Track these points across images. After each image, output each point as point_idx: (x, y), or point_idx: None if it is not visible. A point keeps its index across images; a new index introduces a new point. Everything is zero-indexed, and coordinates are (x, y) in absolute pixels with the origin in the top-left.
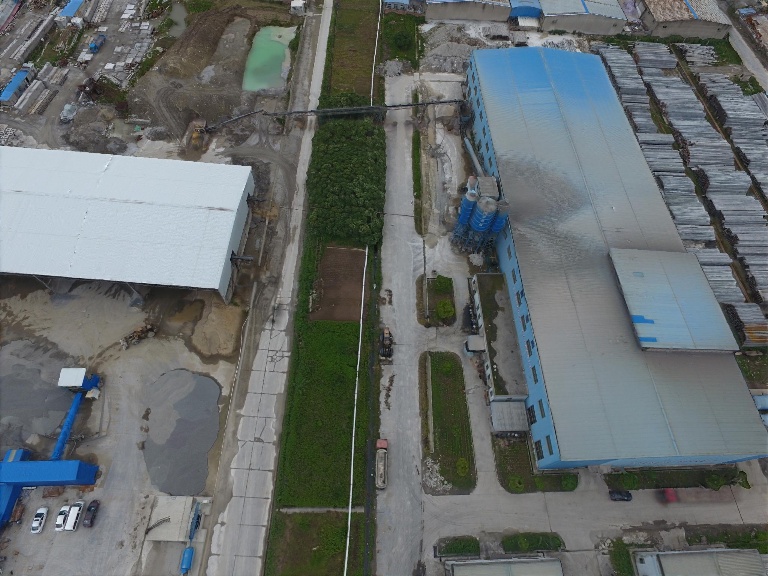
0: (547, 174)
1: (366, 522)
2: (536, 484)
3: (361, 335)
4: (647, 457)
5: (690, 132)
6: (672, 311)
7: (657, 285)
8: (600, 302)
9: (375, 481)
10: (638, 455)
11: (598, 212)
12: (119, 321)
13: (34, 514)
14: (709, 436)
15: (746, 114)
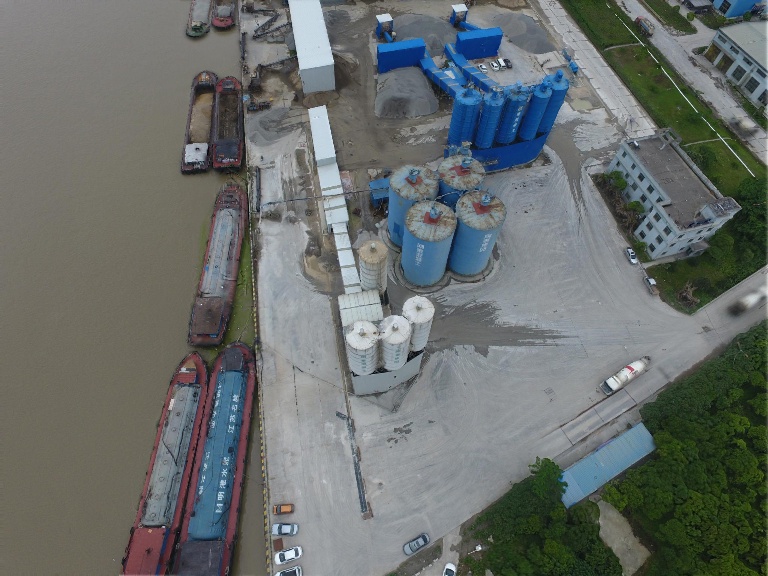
0: None
1: None
2: (730, 21)
3: None
4: None
5: None
6: None
7: None
8: None
9: (648, 30)
10: None
11: None
12: (449, 2)
13: None
14: None
15: None
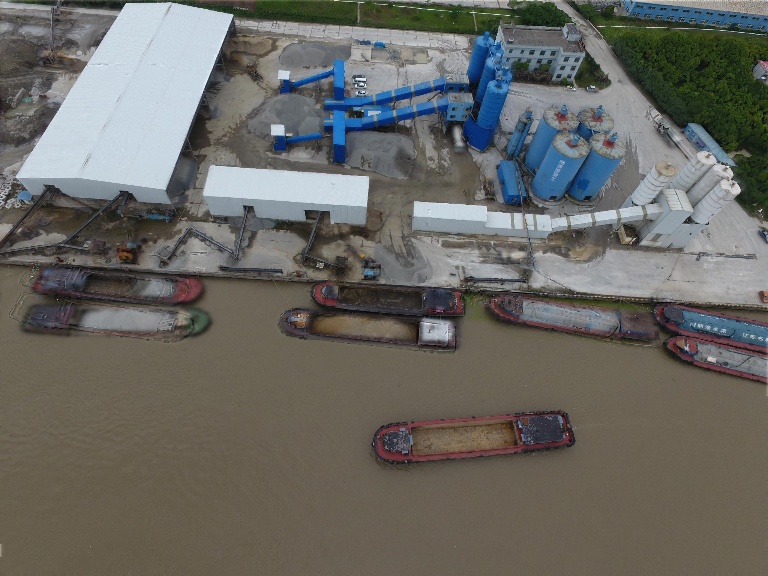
0: None
1: None
2: None
3: None
4: None
5: None
6: None
7: None
8: None
9: None
10: None
11: None
12: (240, 85)
13: None
14: None
15: None
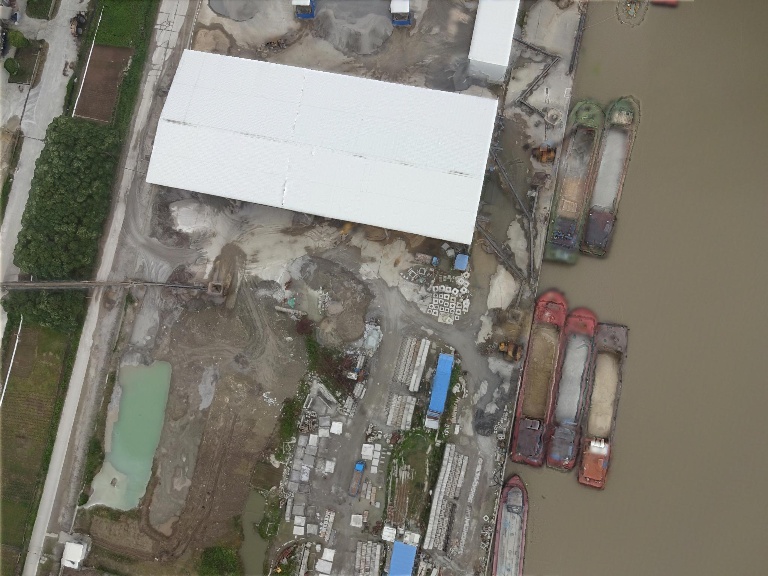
0: None
1: None
2: None
3: None
4: None
5: None
6: None
7: None
8: None
9: None
10: None
11: None
12: None
13: None
14: None
15: None
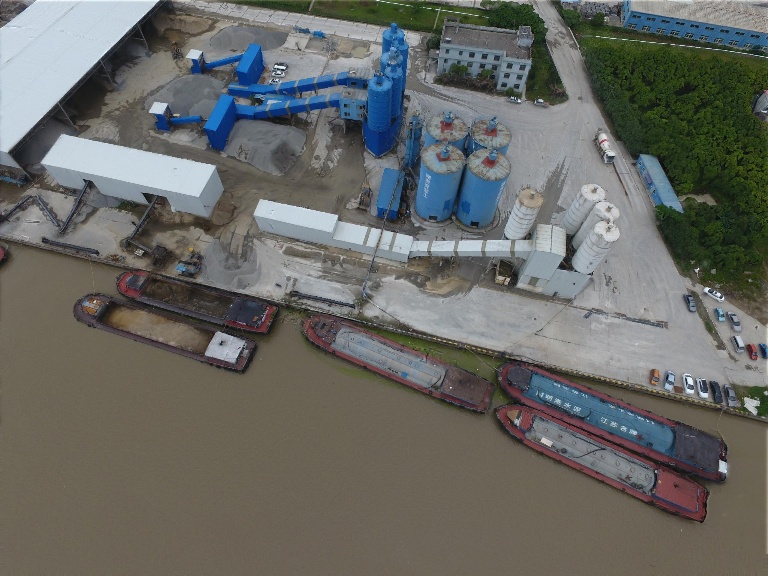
0: None
1: None
2: None
3: None
4: None
5: None
6: None
7: None
8: None
9: None
10: None
11: None
12: (159, 62)
13: None
14: None
15: None
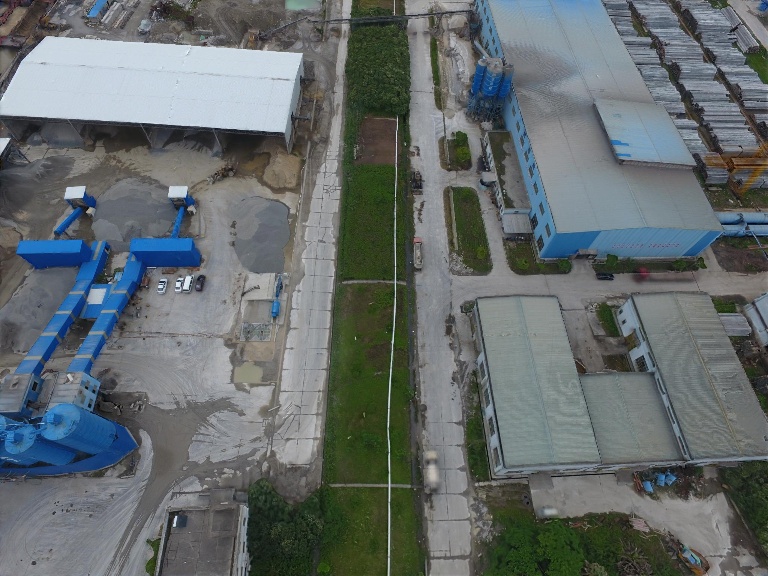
0: (543, 54)
1: (408, 291)
2: None
3: (396, 175)
4: (622, 229)
5: (666, 36)
6: (644, 139)
7: (632, 123)
8: (587, 136)
9: (414, 263)
10: (616, 228)
11: (585, 78)
12: (205, 166)
13: (157, 283)
14: (671, 217)
15: (714, 22)
